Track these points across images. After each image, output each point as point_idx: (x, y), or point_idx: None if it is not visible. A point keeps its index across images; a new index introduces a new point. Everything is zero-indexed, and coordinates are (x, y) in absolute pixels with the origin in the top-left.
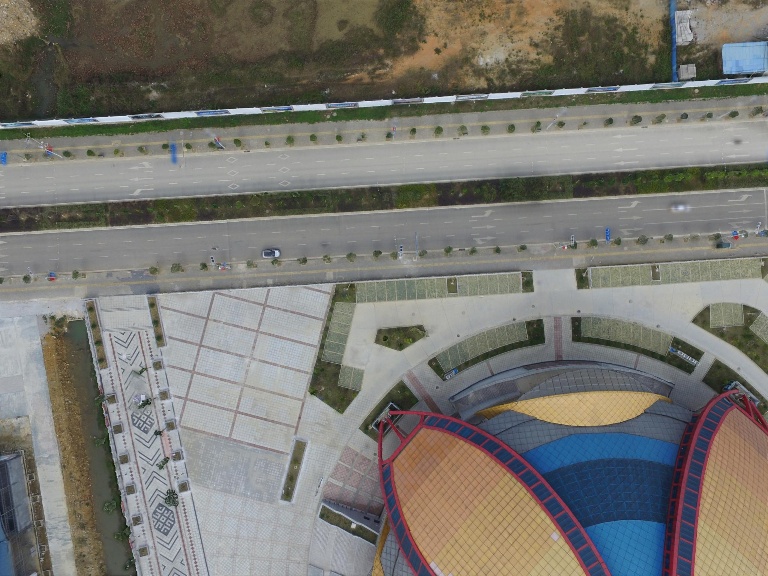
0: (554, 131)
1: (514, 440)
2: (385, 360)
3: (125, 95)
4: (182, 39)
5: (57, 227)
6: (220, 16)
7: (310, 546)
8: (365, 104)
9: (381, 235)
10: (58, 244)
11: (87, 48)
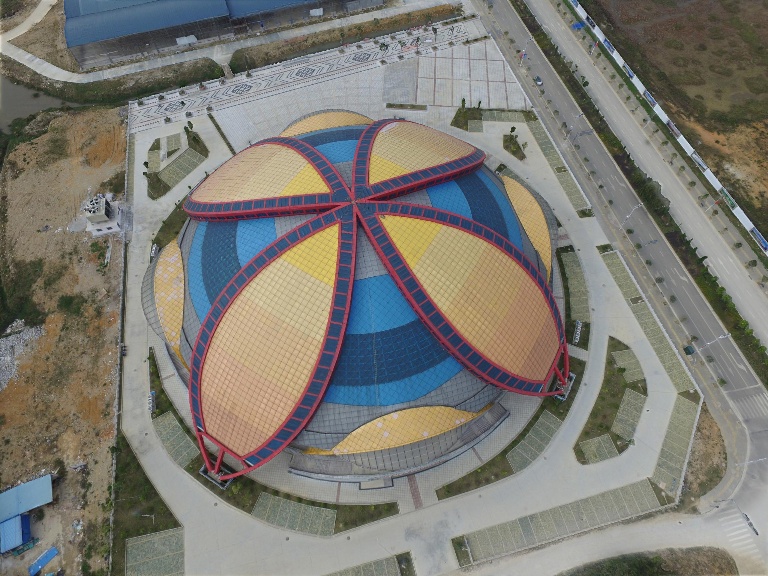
0: (707, 216)
1: (486, 170)
2: (494, 142)
3: (598, 14)
4: (642, 34)
5: (512, 1)
6: (666, 46)
7: None
8: (658, 110)
9: (576, 131)
10: (502, 3)
11: (613, 2)
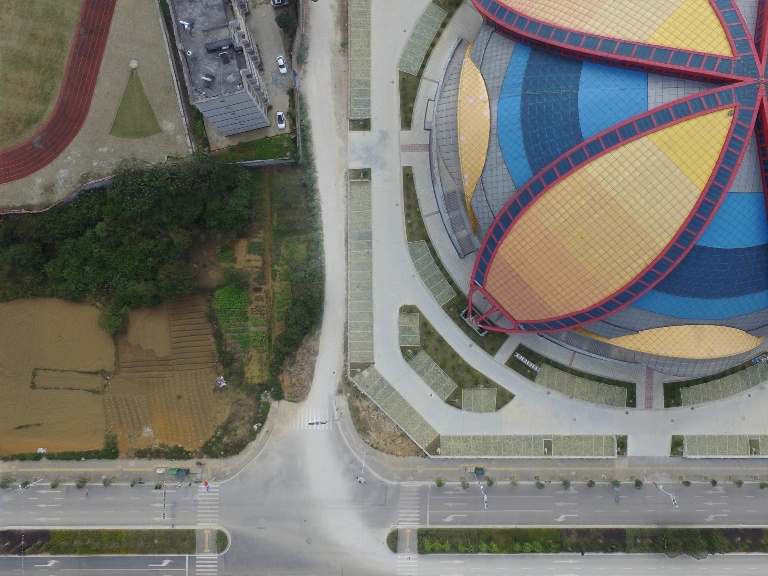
0: None
1: None
2: None
3: None
4: None
5: None
6: None
7: None
8: None
9: None
10: None
11: None
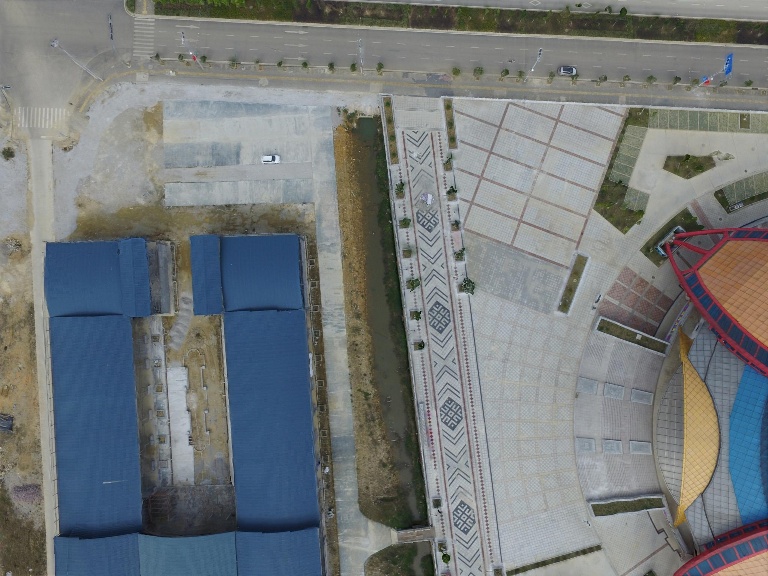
0: None
1: None
2: (671, 187)
3: None
4: None
5: (360, 22)
6: None
7: (581, 360)
8: None
9: (676, 66)
10: (358, 40)
11: None
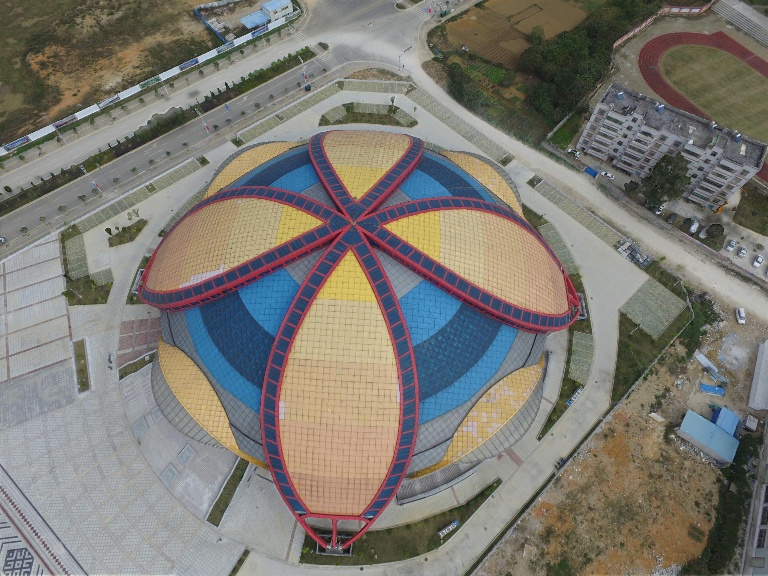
0: (173, 93)
1: None
2: (124, 253)
3: None
4: None
5: None
6: None
7: (126, 412)
8: (35, 136)
9: (84, 192)
10: None
11: None
